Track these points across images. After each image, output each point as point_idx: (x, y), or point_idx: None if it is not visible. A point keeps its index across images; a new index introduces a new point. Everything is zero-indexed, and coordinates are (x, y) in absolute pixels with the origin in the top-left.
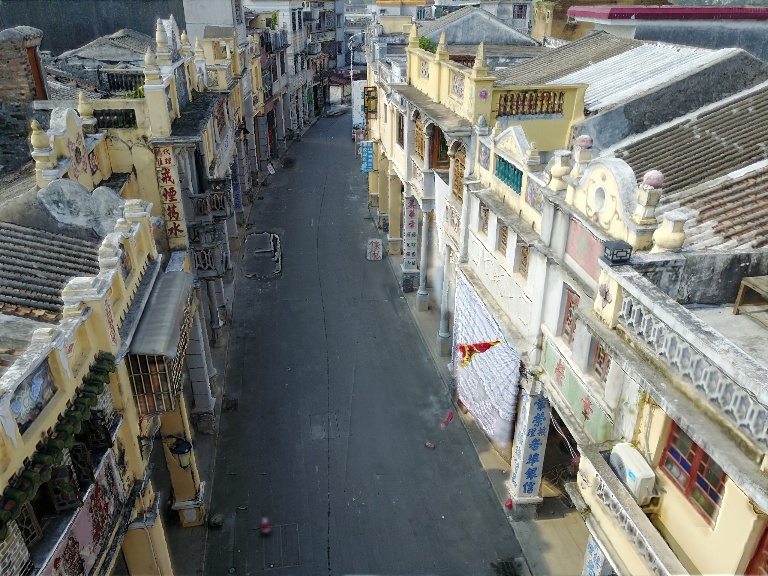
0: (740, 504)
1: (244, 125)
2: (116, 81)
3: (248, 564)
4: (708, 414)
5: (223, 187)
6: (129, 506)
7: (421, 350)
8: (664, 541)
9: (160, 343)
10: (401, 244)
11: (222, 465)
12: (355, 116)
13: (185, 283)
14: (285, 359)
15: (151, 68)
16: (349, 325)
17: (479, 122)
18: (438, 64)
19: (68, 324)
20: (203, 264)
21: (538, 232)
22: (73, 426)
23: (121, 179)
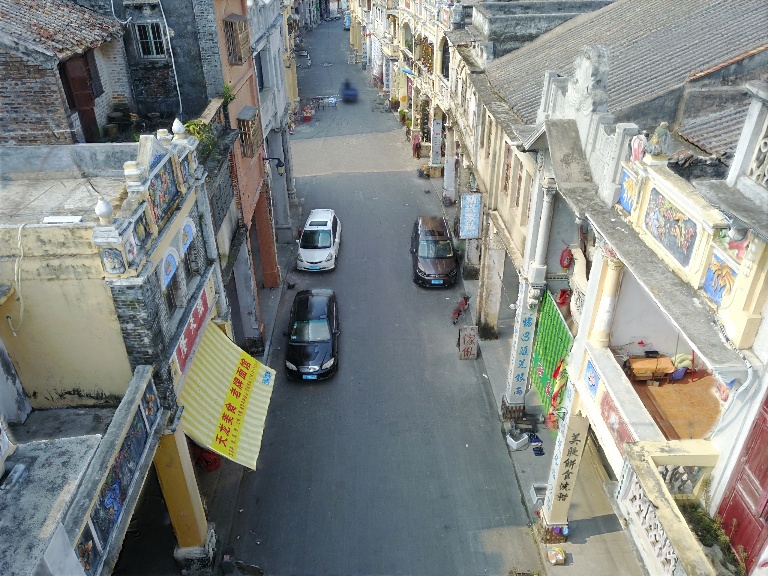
0: None
1: None
2: None
3: None
4: (384, 7)
5: None
6: None
7: (366, 80)
8: None
9: None
10: None
11: (299, 95)
12: (343, 5)
13: None
14: (316, 82)
15: None
16: None
17: None
18: None
19: None
20: None
21: None
22: None
23: None
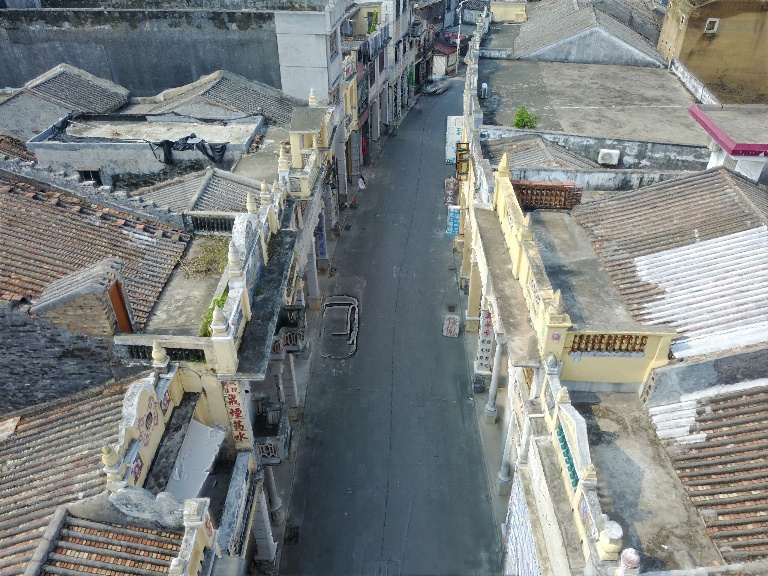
0: None
1: (333, 165)
2: (199, 223)
3: None
4: None
5: (297, 319)
6: None
7: (481, 481)
8: None
9: None
10: (479, 322)
11: None
12: (449, 151)
13: None
14: (348, 477)
15: (218, 324)
16: (414, 435)
17: (548, 362)
18: (519, 246)
19: None
20: (267, 453)
21: (585, 556)
22: None
23: (192, 402)
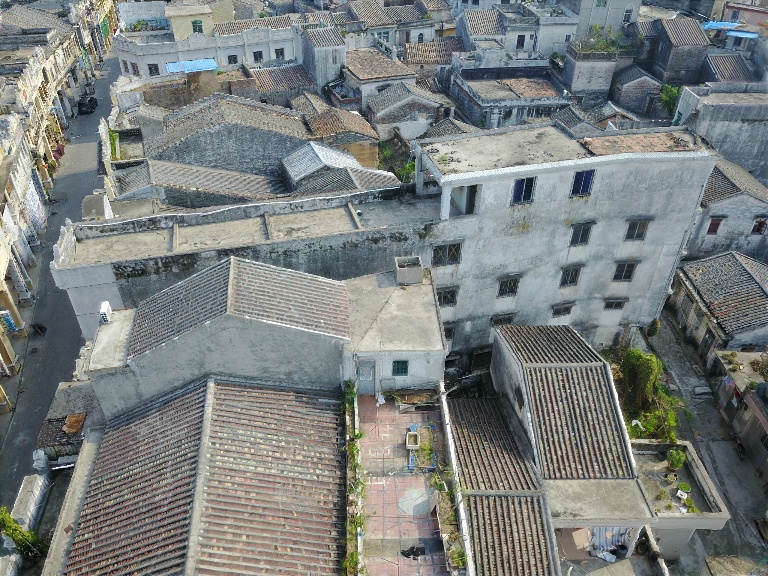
0: (28, 134)
1: None
2: None
3: None
4: None
5: None
6: None
7: (44, 267)
8: None
9: None
10: None
11: None
12: None
13: None
14: None
15: None
16: None
17: None
18: None
19: None
20: None
21: None
22: None
23: None
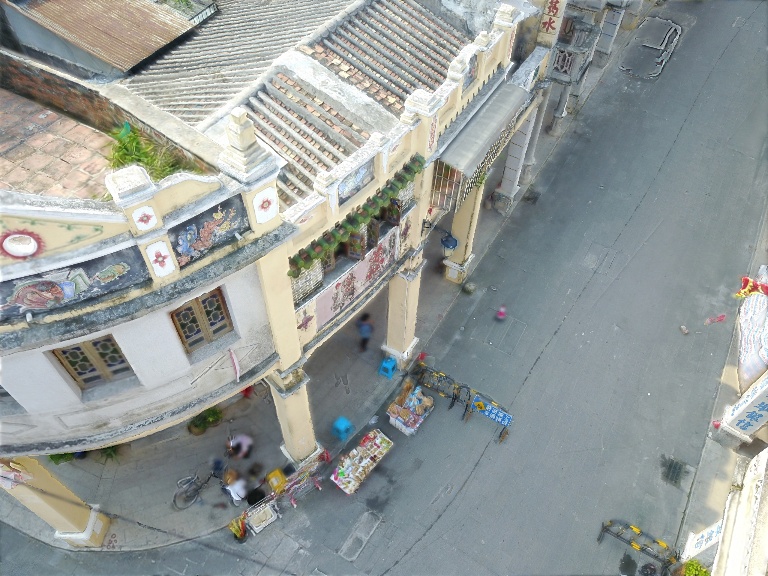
0: None
1: None
2: None
3: (475, 331)
4: None
5: None
6: (399, 264)
7: (750, 233)
8: (767, 558)
9: (465, 159)
10: None
11: (498, 245)
12: None
13: (517, 102)
14: (604, 175)
15: None
16: (691, 169)
17: None
18: None
19: (400, 130)
20: (561, 66)
21: None
22: (374, 209)
23: None
